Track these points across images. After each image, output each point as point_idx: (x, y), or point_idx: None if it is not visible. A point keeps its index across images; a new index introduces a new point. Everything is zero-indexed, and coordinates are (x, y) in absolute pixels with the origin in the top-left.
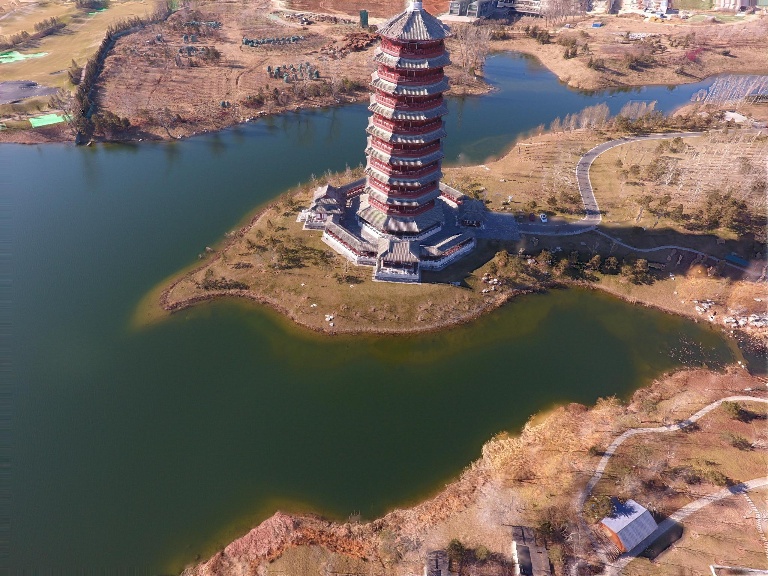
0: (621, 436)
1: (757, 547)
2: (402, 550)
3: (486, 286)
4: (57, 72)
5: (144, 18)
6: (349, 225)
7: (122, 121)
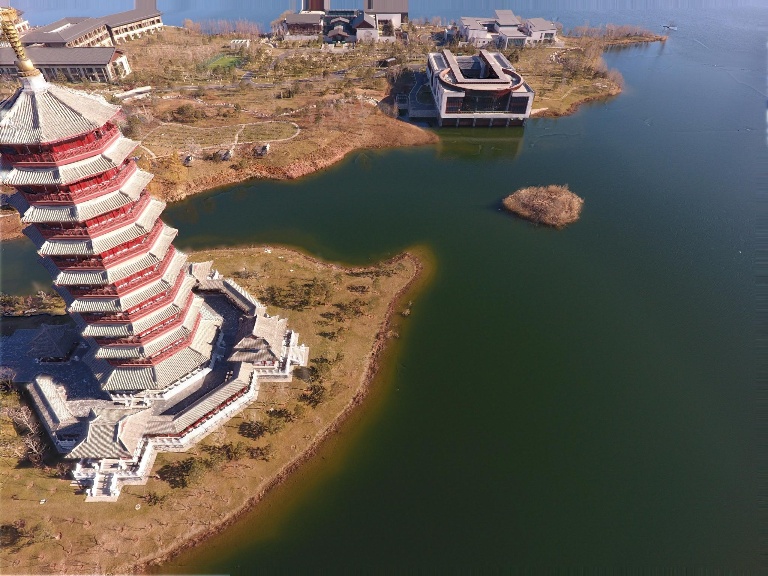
0: None
1: None
2: (239, 166)
3: None
4: None
5: None
6: None
7: None
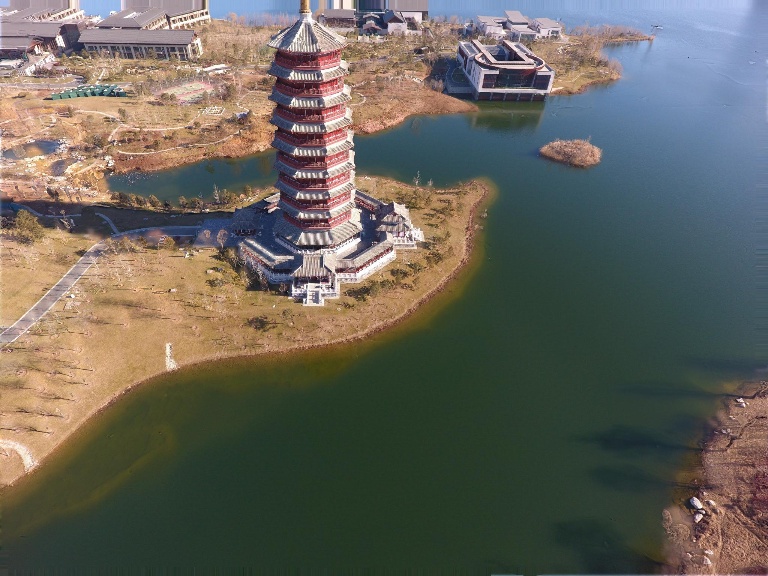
0: (222, 140)
1: (200, 117)
2: None
3: (254, 197)
4: None
5: None
6: (369, 222)
7: None
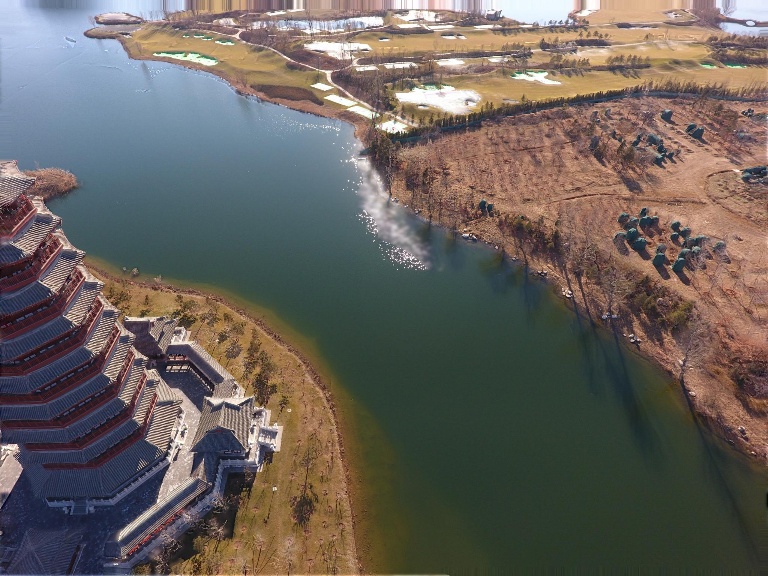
0: None
1: None
2: None
3: None
4: (513, 100)
5: (720, 88)
6: None
7: (385, 156)
